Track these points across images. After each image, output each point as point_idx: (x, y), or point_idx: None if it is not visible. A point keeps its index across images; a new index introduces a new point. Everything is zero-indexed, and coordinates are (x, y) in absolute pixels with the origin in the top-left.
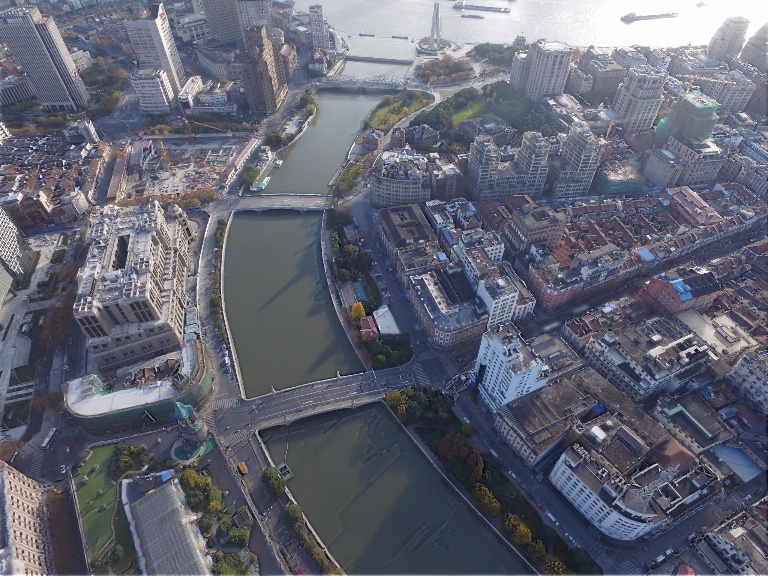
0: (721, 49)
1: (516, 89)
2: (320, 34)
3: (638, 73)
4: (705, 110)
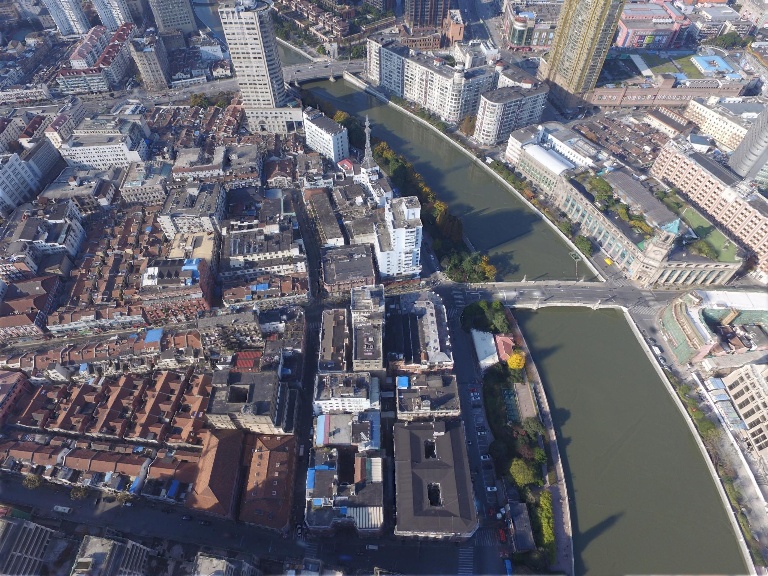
0: None
1: None
2: None
3: None
4: None
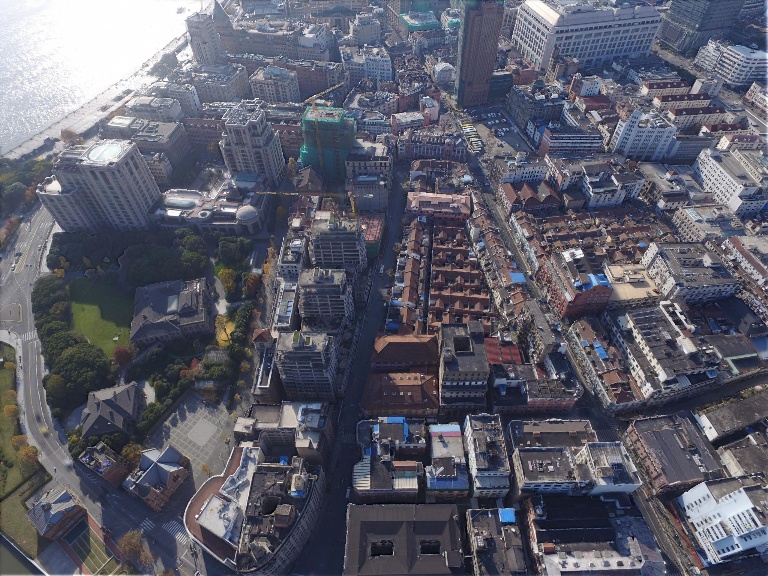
0: (211, 52)
1: (91, 230)
2: None
3: (241, 123)
4: (341, 120)
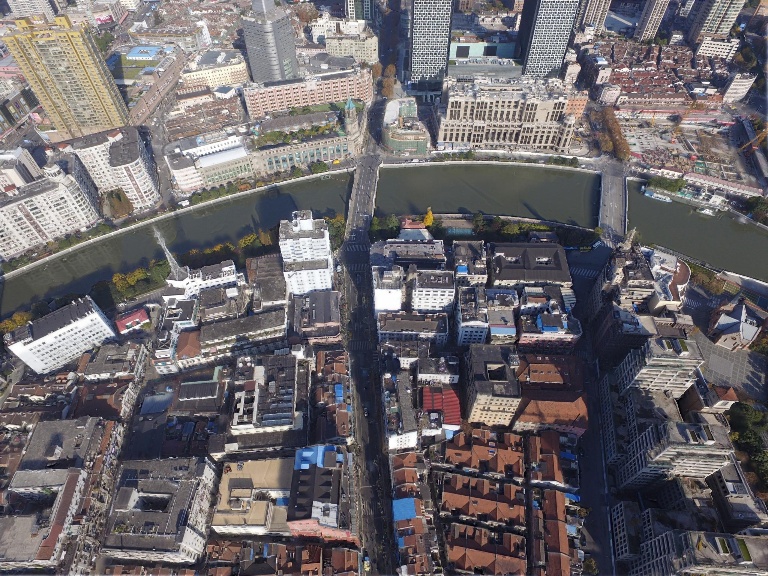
0: None
1: None
2: None
3: None
4: None
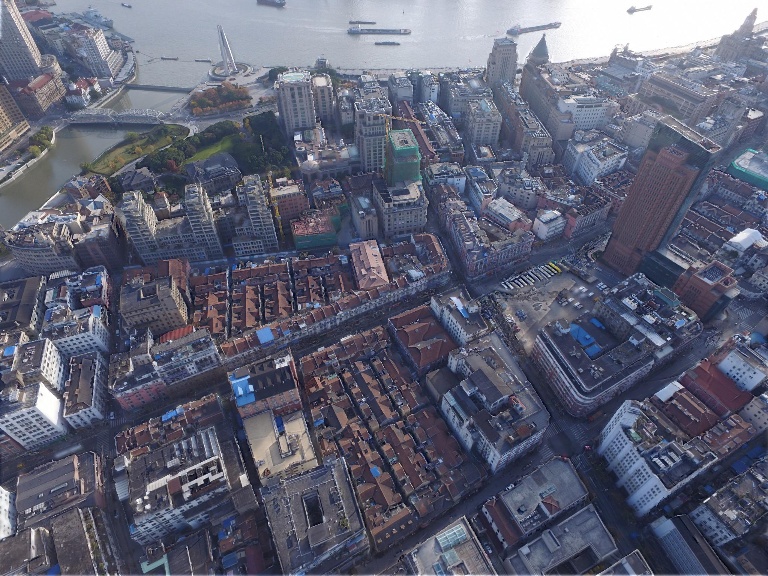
0: (494, 73)
1: (280, 121)
2: (98, 61)
3: (359, 108)
4: (405, 152)
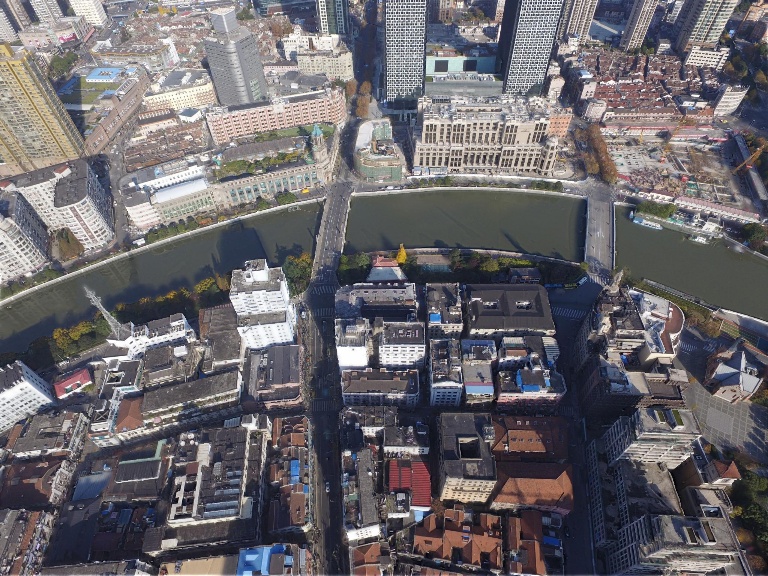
0: None
1: None
2: None
3: None
4: None
